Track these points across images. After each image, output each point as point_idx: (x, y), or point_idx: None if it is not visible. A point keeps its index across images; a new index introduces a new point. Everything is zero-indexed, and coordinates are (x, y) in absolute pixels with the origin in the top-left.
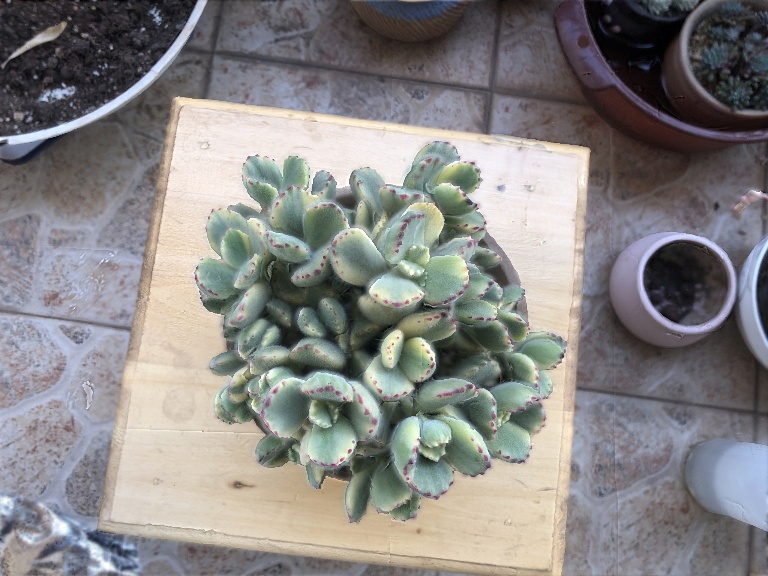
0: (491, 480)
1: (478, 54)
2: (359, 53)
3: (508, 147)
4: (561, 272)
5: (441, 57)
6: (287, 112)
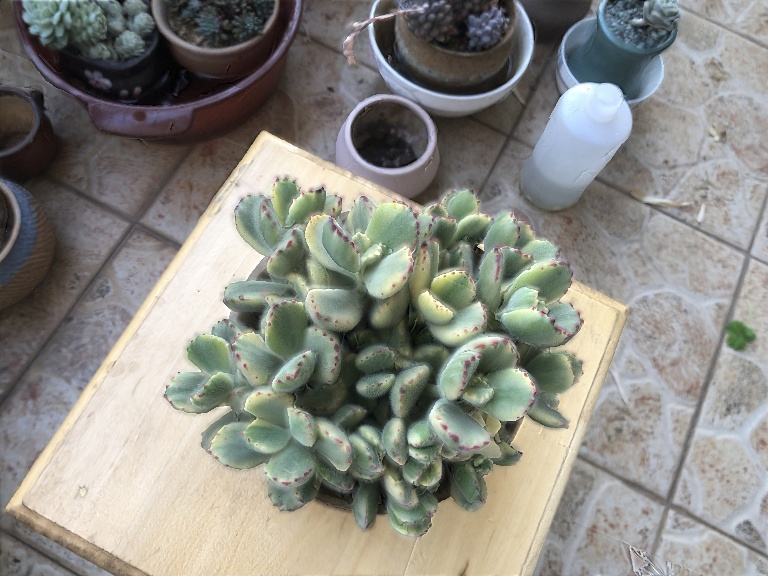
0: None
1: (92, 219)
2: (27, 331)
3: (231, 194)
4: None
5: (76, 254)
6: (89, 389)
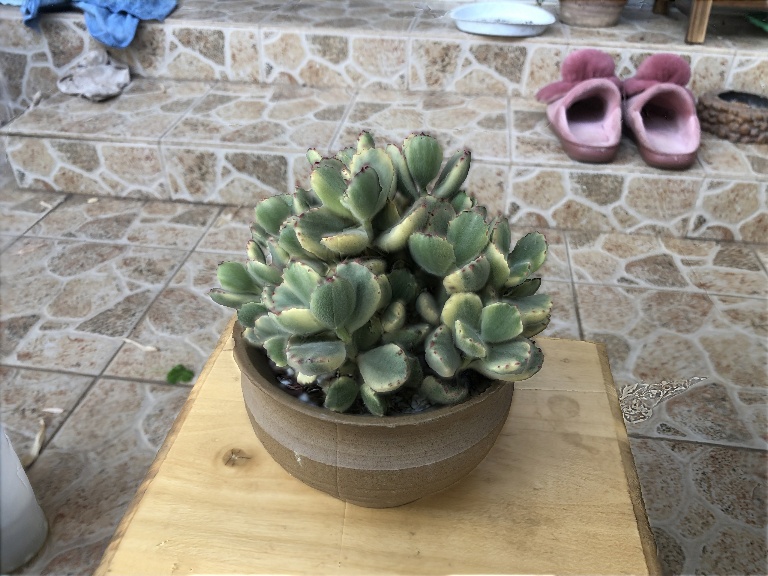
0: None
1: None
2: None
3: None
4: (151, 511)
5: None
6: None
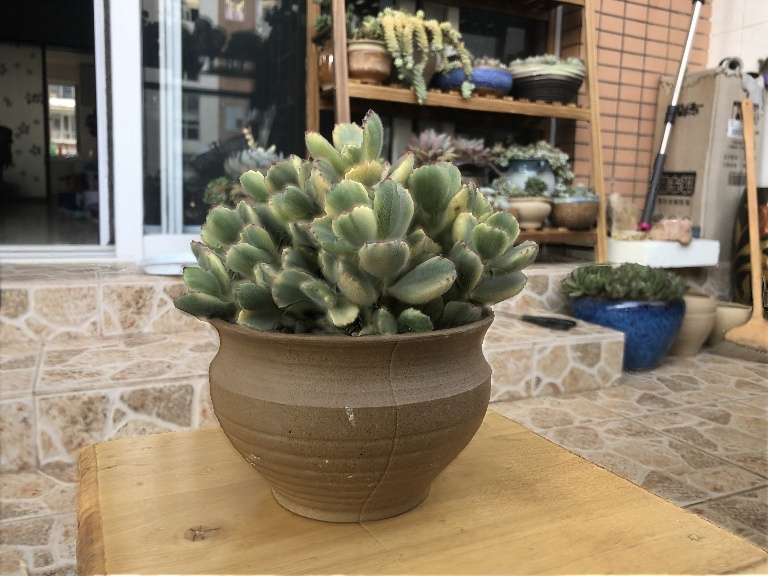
0: (173, 461)
1: None
2: None
3: None
4: None
5: None
6: None
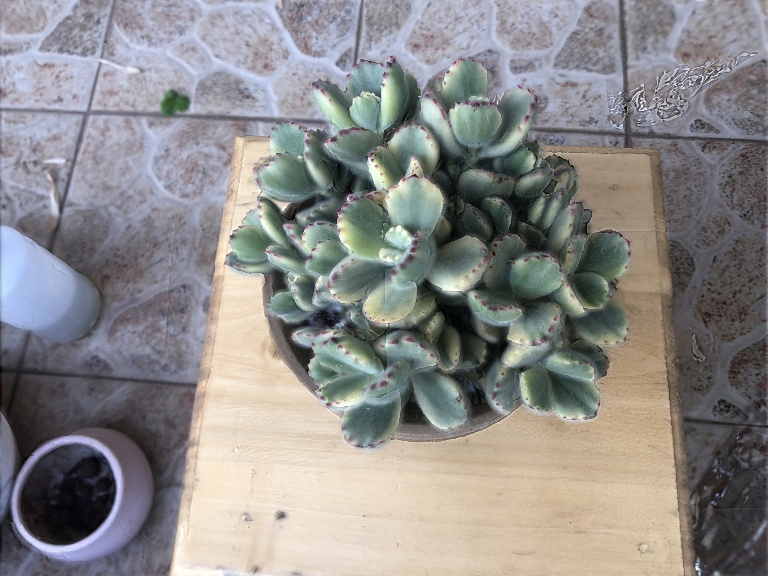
0: None
1: None
2: None
3: (270, 572)
4: (216, 417)
5: None
6: None
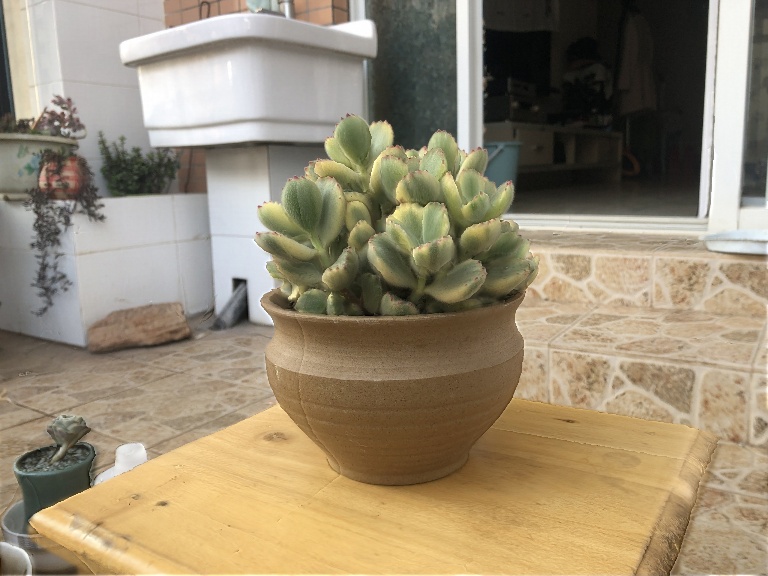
0: None
1: None
2: None
3: (108, 530)
4: (187, 449)
5: None
6: None
